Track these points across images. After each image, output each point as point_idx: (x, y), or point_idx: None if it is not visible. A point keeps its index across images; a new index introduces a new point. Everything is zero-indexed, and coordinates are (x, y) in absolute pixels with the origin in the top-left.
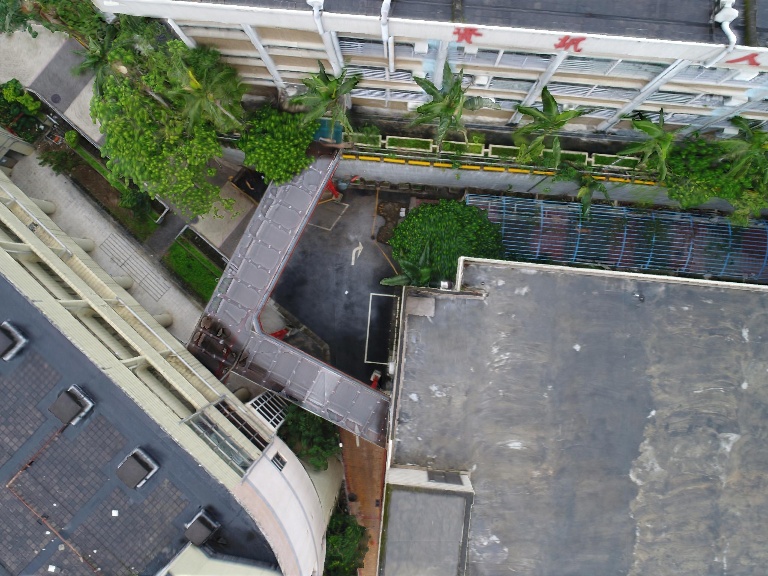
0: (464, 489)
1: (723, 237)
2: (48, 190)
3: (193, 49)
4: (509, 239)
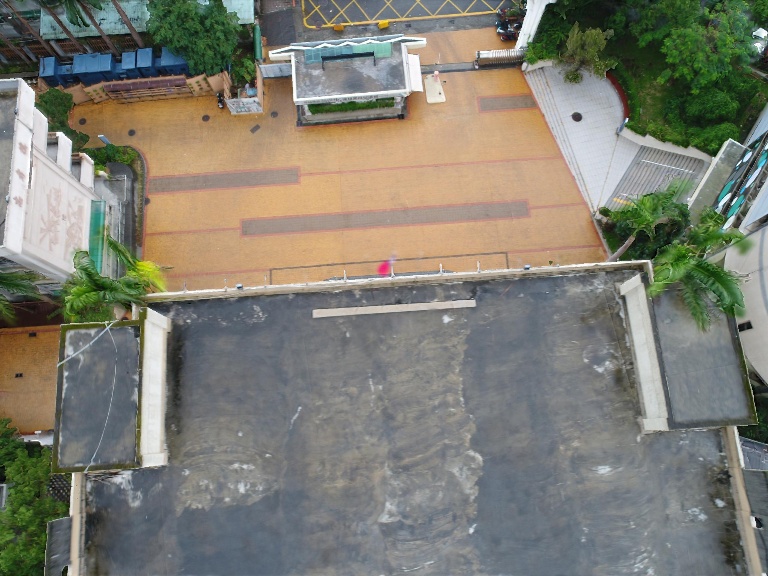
0: None
1: None
2: None
3: None
4: None
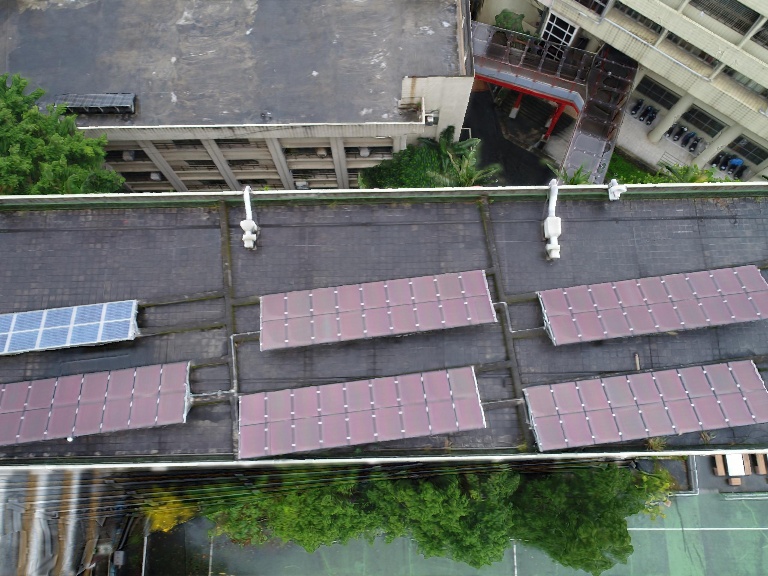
0: None
1: None
2: None
3: None
4: None
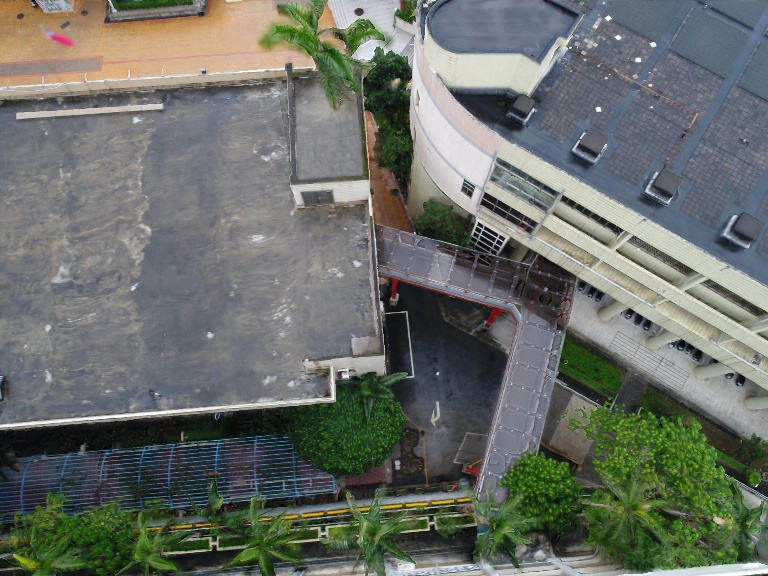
0: (300, 187)
1: (68, 493)
2: (759, 422)
3: (654, 568)
4: (286, 451)
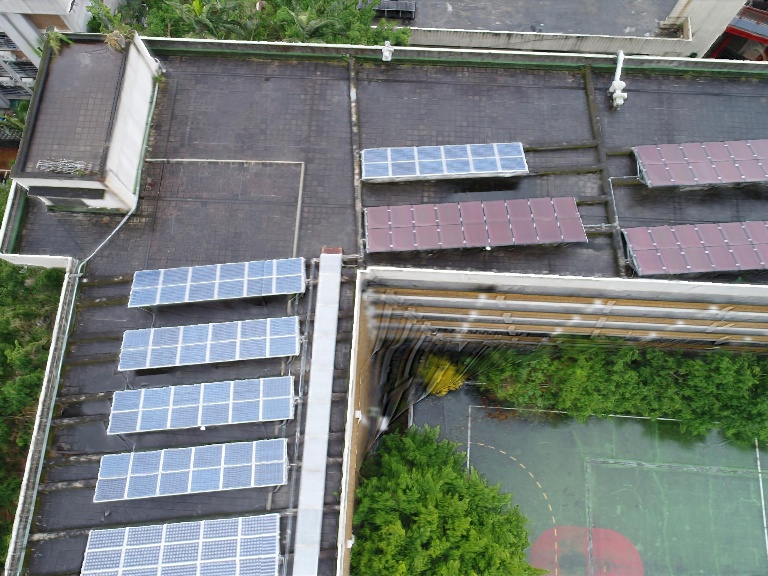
0: None
1: None
2: None
3: None
4: None
